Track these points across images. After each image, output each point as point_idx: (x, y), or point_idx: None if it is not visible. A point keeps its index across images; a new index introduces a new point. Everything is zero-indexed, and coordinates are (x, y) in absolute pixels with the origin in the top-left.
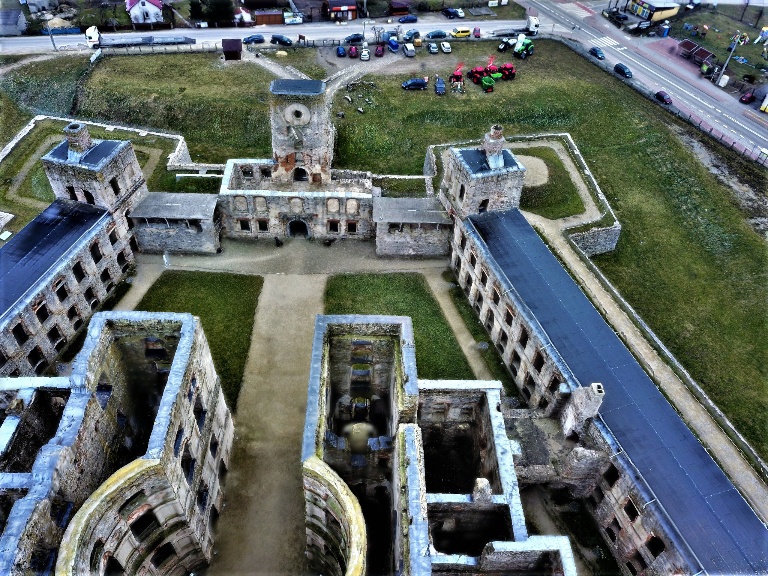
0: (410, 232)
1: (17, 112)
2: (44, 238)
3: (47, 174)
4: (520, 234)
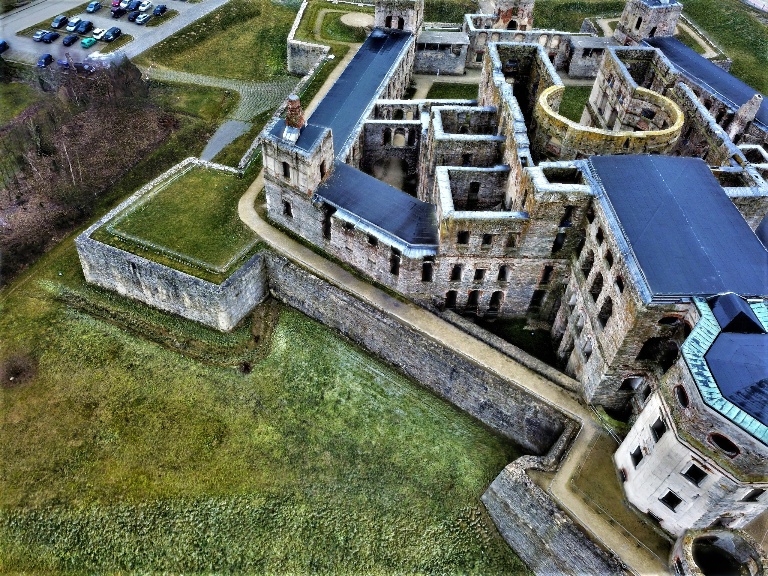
0: (596, 57)
1: (271, 3)
2: (384, 43)
3: (376, 8)
4: (679, 47)
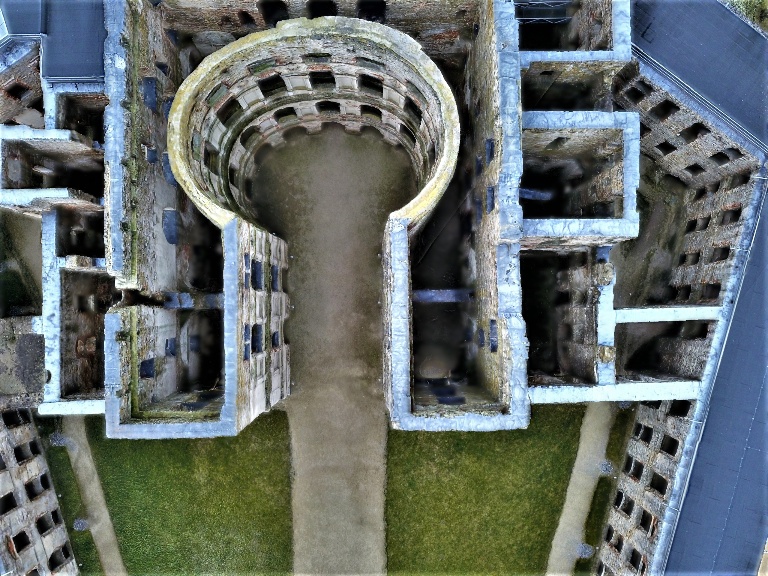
0: None
1: None
2: None
3: None
4: None
